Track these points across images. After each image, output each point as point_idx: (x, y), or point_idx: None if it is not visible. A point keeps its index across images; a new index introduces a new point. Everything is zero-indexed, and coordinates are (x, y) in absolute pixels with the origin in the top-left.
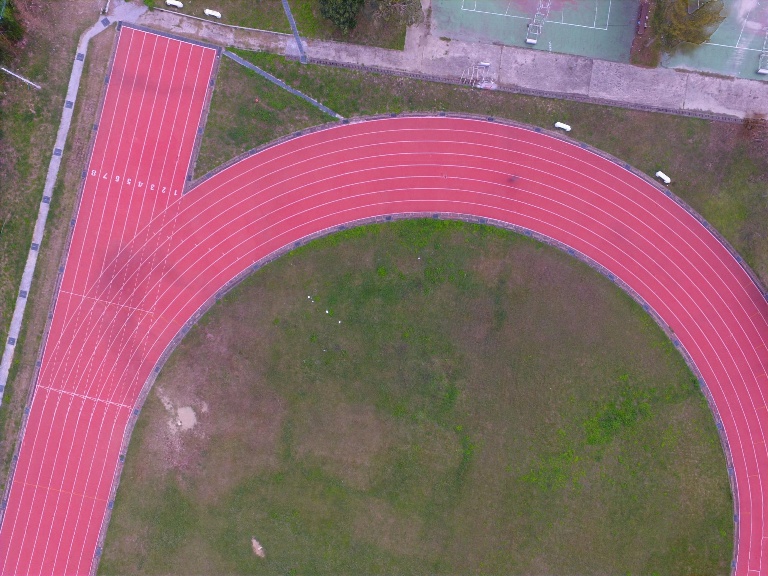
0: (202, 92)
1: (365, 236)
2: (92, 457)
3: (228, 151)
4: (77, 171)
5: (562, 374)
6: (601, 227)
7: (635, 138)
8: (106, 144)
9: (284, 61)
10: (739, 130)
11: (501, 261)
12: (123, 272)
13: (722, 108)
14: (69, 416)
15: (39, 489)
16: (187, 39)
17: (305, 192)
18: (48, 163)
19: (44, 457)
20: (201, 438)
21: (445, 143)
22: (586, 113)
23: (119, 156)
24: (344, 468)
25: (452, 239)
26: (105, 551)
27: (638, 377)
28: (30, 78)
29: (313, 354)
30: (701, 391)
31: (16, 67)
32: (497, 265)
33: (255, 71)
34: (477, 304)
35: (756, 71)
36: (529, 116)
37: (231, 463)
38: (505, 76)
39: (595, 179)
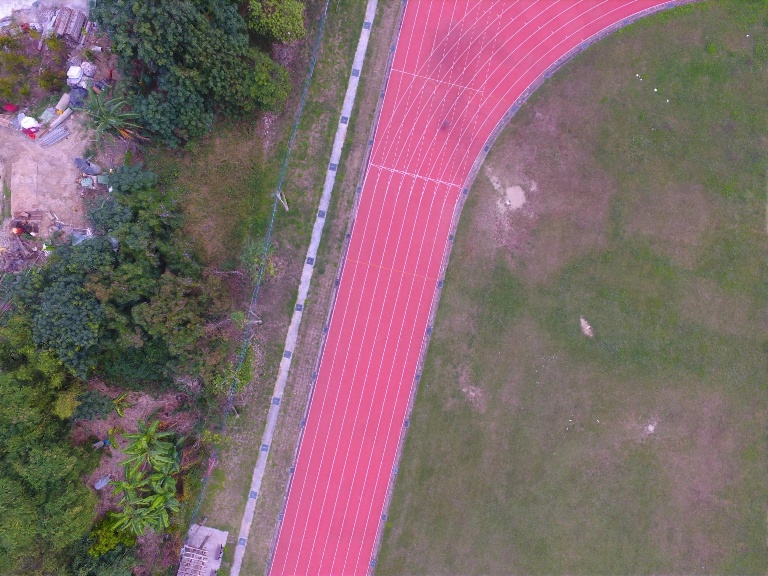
0: None
1: (694, 13)
2: (422, 236)
3: None
4: None
5: None
6: None
7: None
8: None
9: None
10: None
11: None
12: (454, 51)
13: None
14: (400, 195)
15: (371, 268)
16: None
17: None
18: None
19: (376, 236)
20: (530, 217)
21: None
22: None
23: None
24: (672, 247)
25: None
26: (435, 330)
27: None
28: None
29: (641, 133)
30: None
31: None
32: None
33: None
34: None
35: None
36: None
37: (560, 242)
38: None
39: None
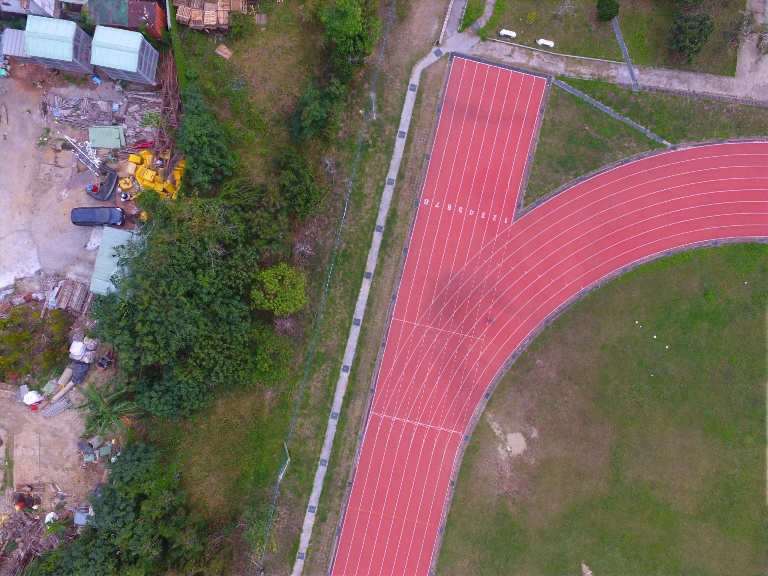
0: (532, 120)
1: (692, 261)
2: (424, 483)
3: (557, 178)
4: (409, 200)
5: None
6: None
7: None
8: (438, 173)
9: (616, 89)
10: None
11: None
12: (454, 299)
13: None
14: (401, 442)
15: (373, 515)
16: (517, 68)
17: (633, 218)
18: (381, 193)
19: (378, 483)
20: (531, 463)
21: None
22: None
23: (451, 185)
24: (672, 492)
25: None
26: None
27: None
28: (366, 109)
29: (641, 379)
30: None
31: (353, 99)
32: None
33: (584, 99)
34: None
35: None
36: None
37: (561, 488)
38: None
39: None
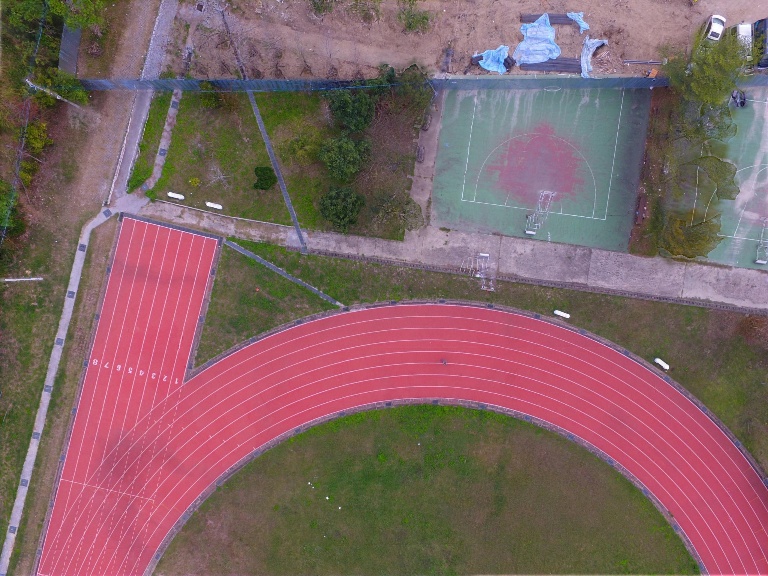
0: (203, 281)
1: (365, 422)
2: None
3: (229, 339)
4: (79, 360)
5: (562, 559)
6: (600, 412)
7: (634, 325)
8: (107, 333)
9: (285, 252)
10: (737, 318)
11: (501, 446)
12: (124, 460)
13: (720, 297)
14: None
15: None
16: (188, 229)
17: (305, 379)
18: (50, 352)
19: None
20: None
21: (445, 330)
22: (585, 301)
23: (120, 345)
24: None
25: (452, 425)
26: None
27: (638, 562)
28: (32, 270)
29: (313, 540)
30: (701, 575)
31: (18, 259)
32: (497, 450)
33: (256, 260)
34: (477, 489)
35: (754, 261)
36: (528, 303)
37: None
38: (504, 266)
39: (594, 365)
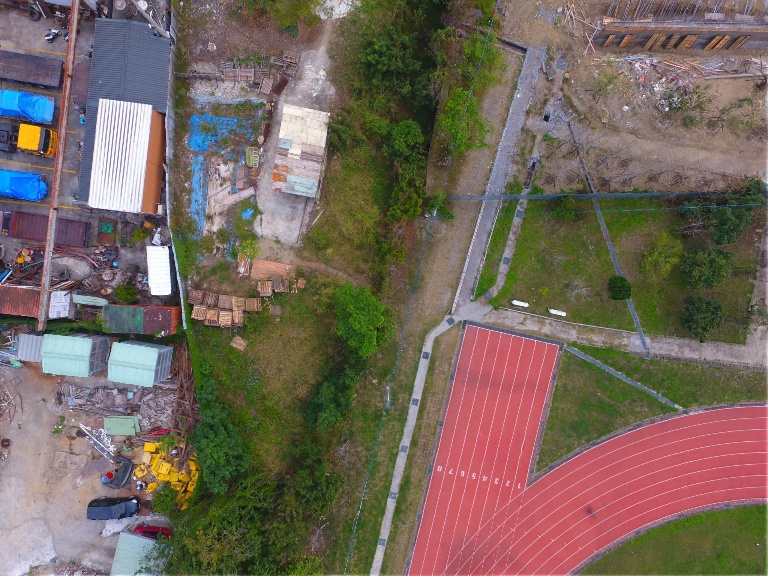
0: (545, 387)
1: (704, 524)
2: None
3: (570, 443)
4: (423, 467)
5: None
6: None
7: None
8: (451, 440)
9: (628, 358)
10: None
11: None
12: (468, 564)
13: None
14: None
15: None
16: (530, 335)
17: (645, 482)
18: (395, 460)
19: None
20: None
21: None
22: None
23: (464, 451)
24: None
25: None
26: None
27: None
28: (379, 379)
29: None
30: None
31: (366, 369)
32: None
33: (596, 365)
34: None
35: None
36: None
37: None
38: None
39: None
